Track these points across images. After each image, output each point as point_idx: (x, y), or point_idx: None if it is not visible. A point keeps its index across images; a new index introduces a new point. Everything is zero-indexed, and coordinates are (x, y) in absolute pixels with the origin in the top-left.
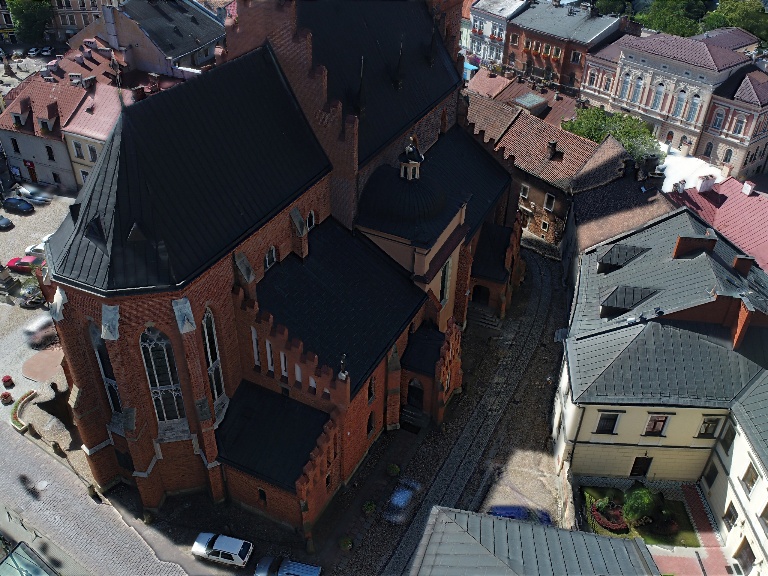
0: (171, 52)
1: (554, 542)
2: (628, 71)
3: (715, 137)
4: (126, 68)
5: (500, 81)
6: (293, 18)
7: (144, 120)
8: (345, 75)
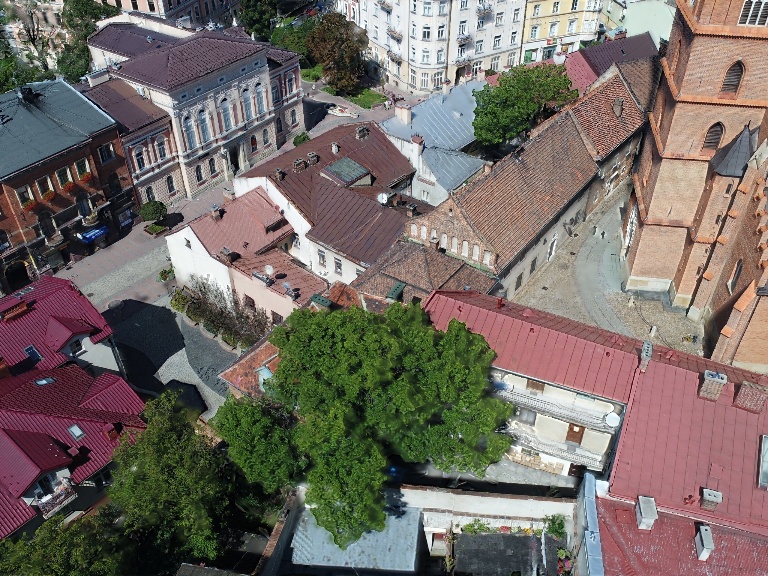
0: None
1: None
2: (188, 114)
3: (280, 110)
4: None
5: (239, 208)
6: None
7: None
8: None
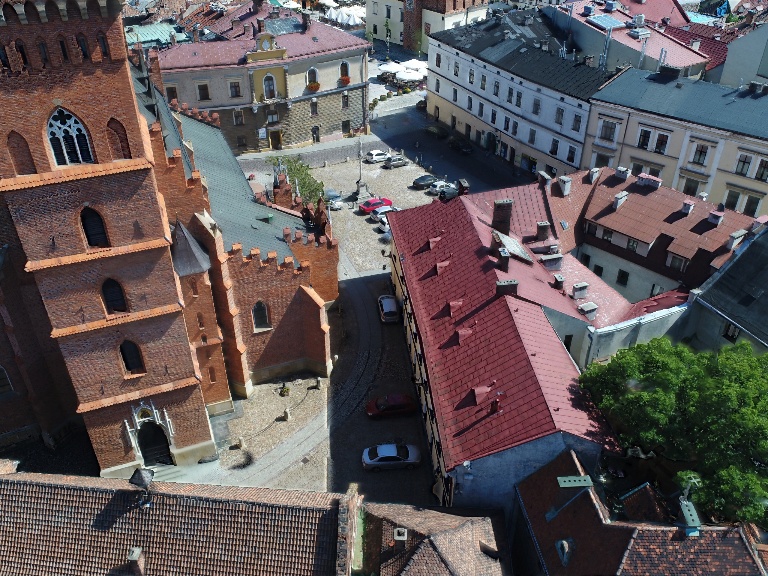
0: (729, 299)
1: None
2: None
3: None
4: None
5: None
6: None
7: None
8: None
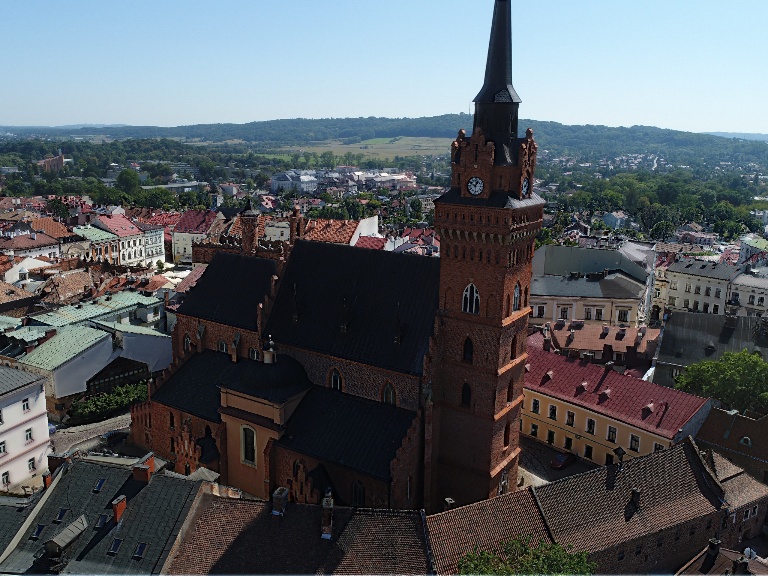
0: (670, 357)
1: (1, 384)
2: None
3: None
4: (643, 355)
5: None
6: (285, 250)
7: (220, 258)
8: (309, 296)
